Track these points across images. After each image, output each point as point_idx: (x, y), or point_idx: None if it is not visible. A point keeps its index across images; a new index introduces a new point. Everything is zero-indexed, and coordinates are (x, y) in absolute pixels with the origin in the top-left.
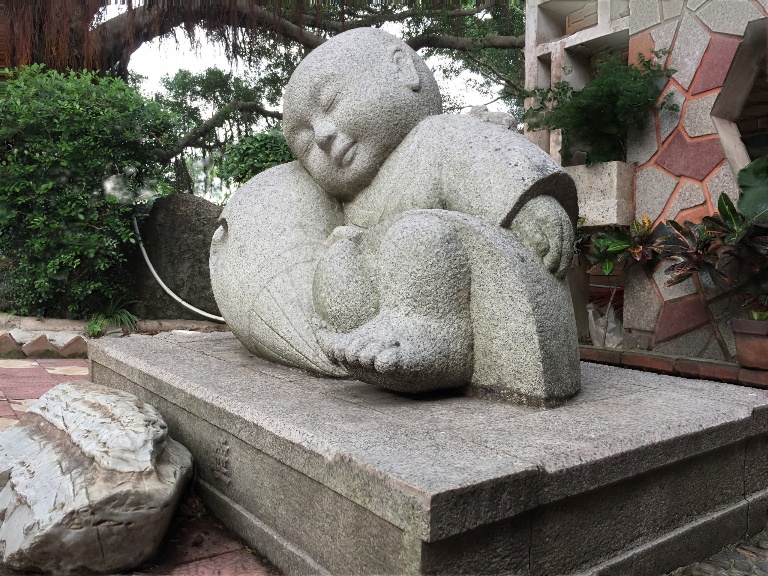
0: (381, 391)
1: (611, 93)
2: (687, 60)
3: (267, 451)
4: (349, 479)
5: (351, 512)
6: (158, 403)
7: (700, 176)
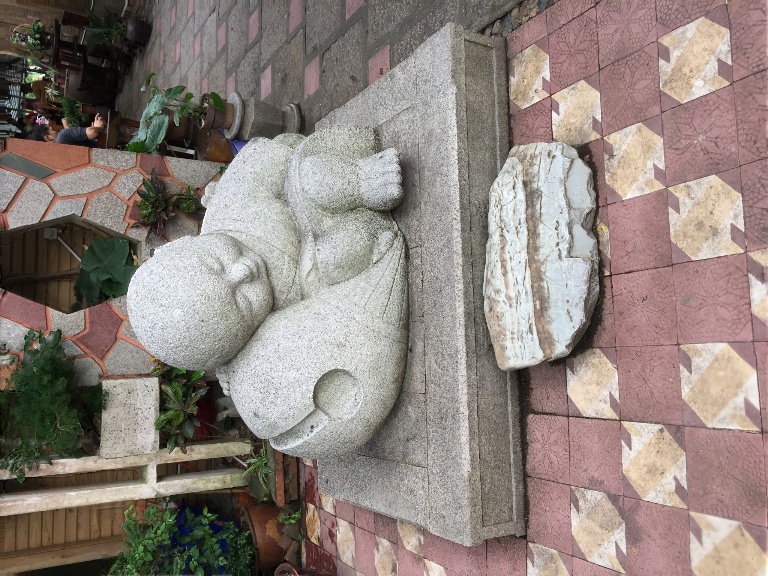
0: None
1: (52, 365)
2: (13, 334)
3: None
4: (458, 72)
5: (469, 79)
6: (479, 326)
7: (118, 320)
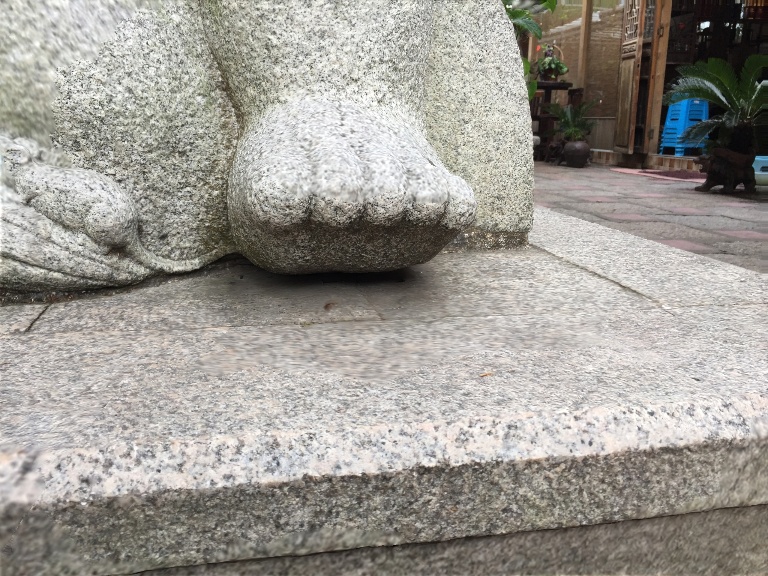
0: (304, 285)
1: None
2: None
3: (530, 523)
4: None
5: None
6: None
7: None
